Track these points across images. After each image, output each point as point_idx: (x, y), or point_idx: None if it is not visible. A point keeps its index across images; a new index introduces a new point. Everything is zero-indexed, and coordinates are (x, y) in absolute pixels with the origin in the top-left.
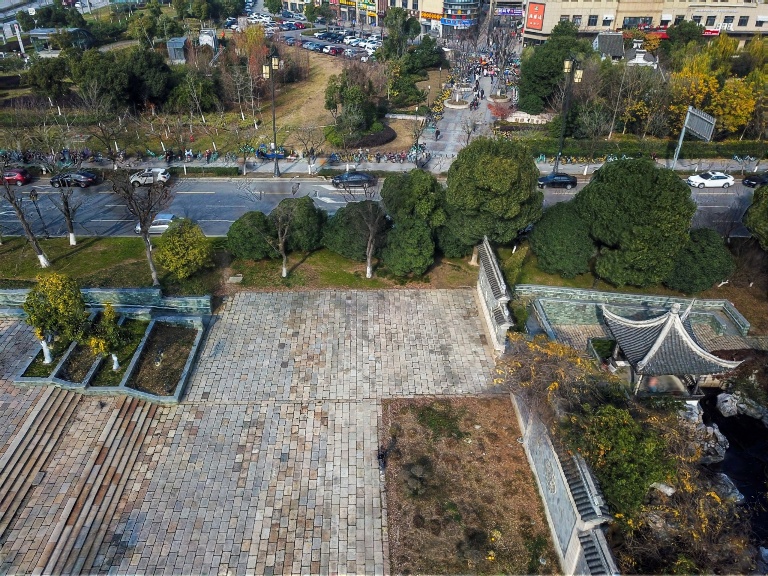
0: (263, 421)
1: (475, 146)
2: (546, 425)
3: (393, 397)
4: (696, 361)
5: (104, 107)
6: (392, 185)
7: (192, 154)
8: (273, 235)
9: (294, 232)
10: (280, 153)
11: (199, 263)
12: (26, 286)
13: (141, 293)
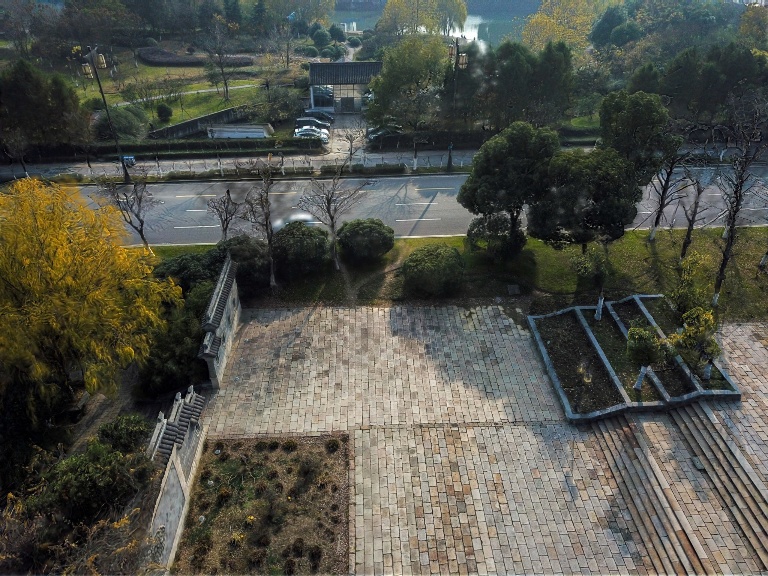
0: None
1: None
2: None
3: None
4: None
5: None
6: None
7: None
8: None
9: None
10: None
11: None
12: None
13: None
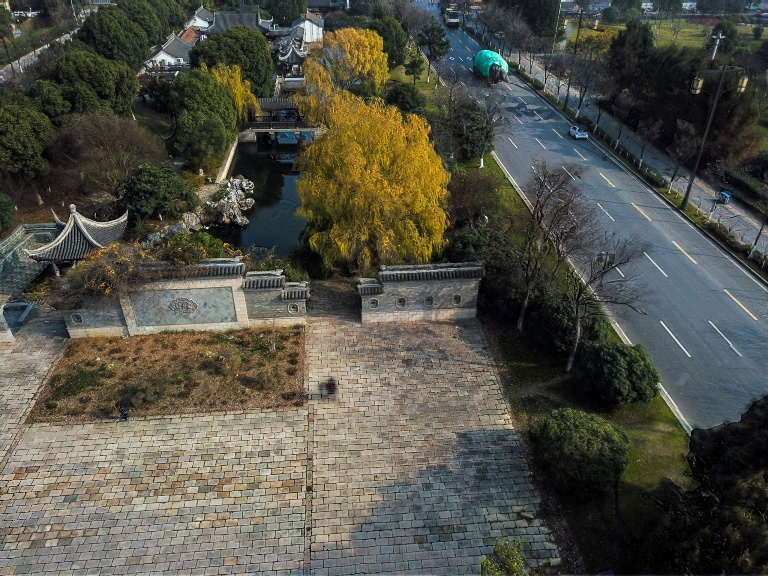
0: None
1: None
2: (162, 278)
3: (26, 415)
4: (110, 230)
5: None
6: None
7: None
8: None
9: None
10: None
11: None
12: None
13: None
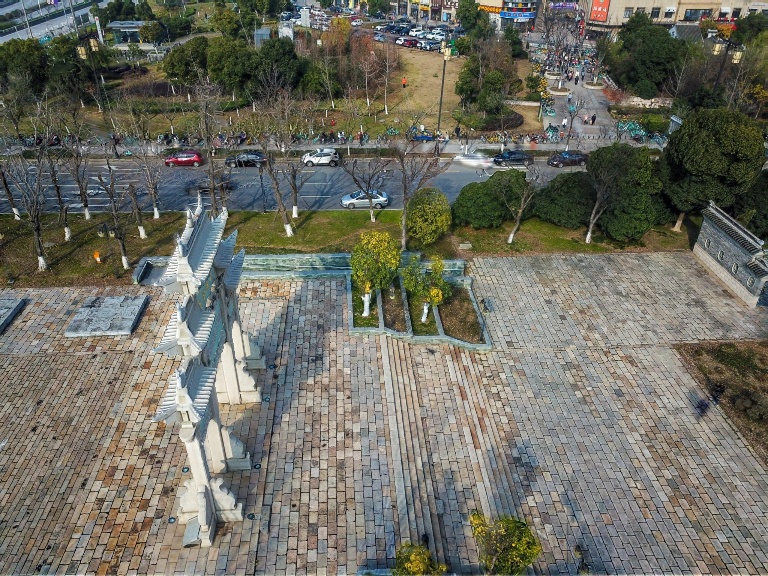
0: (578, 364)
1: (710, 116)
2: None
3: (681, 342)
4: None
5: (283, 89)
6: (609, 156)
7: (345, 137)
8: (500, 204)
9: (510, 202)
10: (429, 135)
11: (444, 229)
12: (287, 252)
13: (404, 256)
